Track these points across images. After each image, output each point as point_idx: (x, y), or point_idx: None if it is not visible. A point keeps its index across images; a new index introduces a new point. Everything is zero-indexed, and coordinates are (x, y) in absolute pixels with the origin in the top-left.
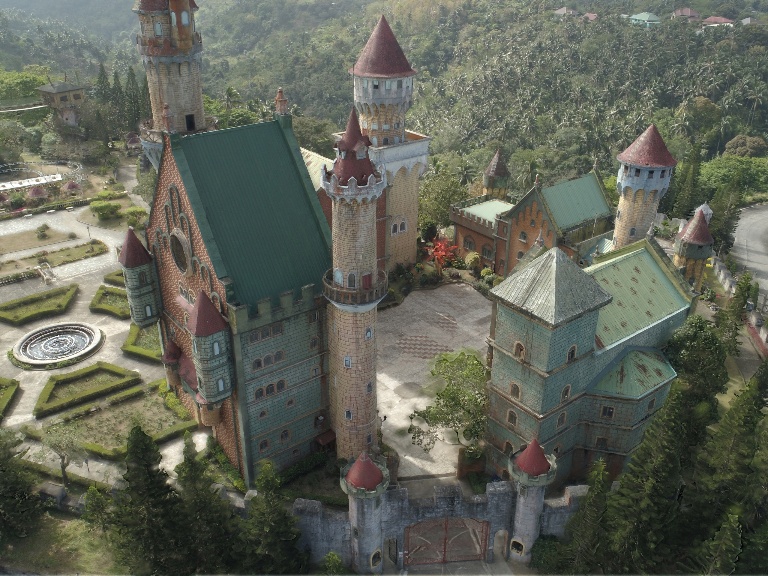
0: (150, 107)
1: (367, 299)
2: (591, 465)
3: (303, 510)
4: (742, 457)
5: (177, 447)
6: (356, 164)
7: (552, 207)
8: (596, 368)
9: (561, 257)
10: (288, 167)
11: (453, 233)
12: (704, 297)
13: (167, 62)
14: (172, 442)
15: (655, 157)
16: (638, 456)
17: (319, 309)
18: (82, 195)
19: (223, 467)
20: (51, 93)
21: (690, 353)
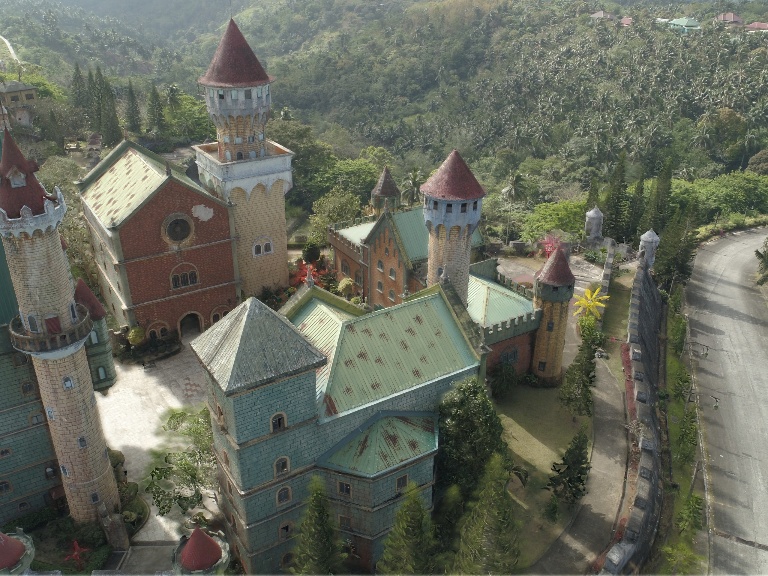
0: (111, 108)
1: (48, 346)
2: (339, 546)
3: None
4: (410, 574)
5: None
6: (12, 193)
7: (405, 235)
8: (330, 437)
9: (257, 309)
10: None
11: (333, 256)
12: None
13: None
14: None
15: (453, 188)
16: (300, 559)
17: None
18: None
19: None
20: (2, 93)
21: (458, 423)
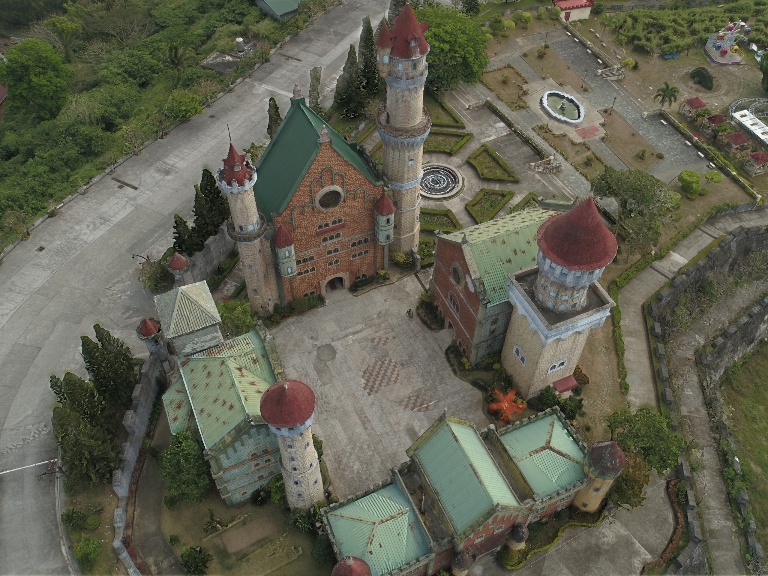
0: None
1: None
2: None
3: None
4: None
5: None
6: None
7: (435, 442)
8: None
9: None
10: None
11: None
12: None
13: None
14: None
15: None
16: None
17: None
18: (755, 169)
19: None
20: None
21: None
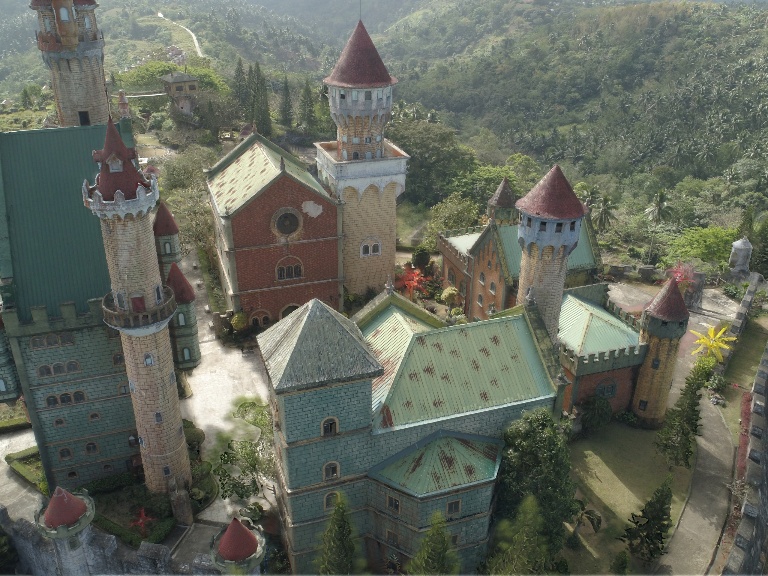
0: (264, 102)
1: (132, 323)
2: (386, 560)
3: (17, 531)
4: None
5: (31, 436)
6: (110, 177)
7: (509, 249)
8: (384, 449)
9: (319, 311)
10: None
11: (442, 263)
12: (708, 385)
13: (55, 57)
14: (31, 430)
15: (549, 206)
16: None
17: None
18: None
19: None
20: (169, 82)
21: (521, 455)
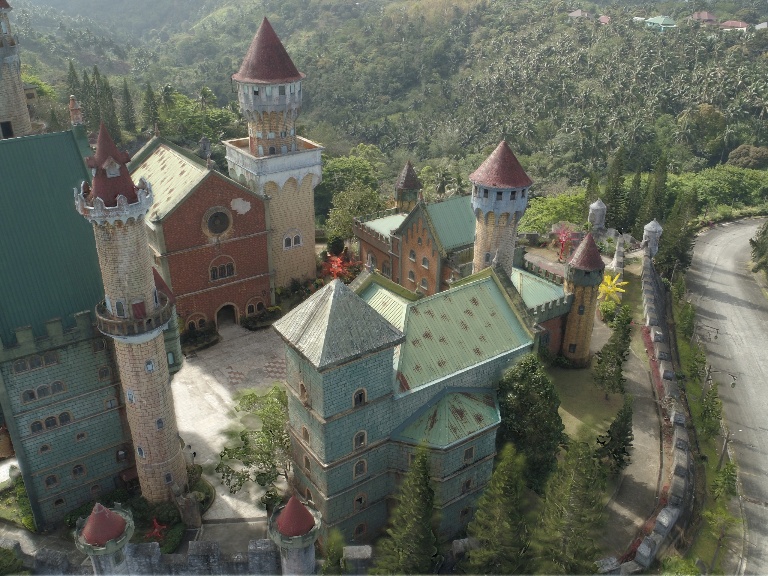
0: (110, 107)
1: (136, 330)
2: None
3: (43, 562)
4: (506, 530)
5: None
6: (107, 183)
7: (438, 225)
8: (402, 412)
9: (342, 290)
10: (80, 181)
11: (358, 248)
12: (613, 324)
13: None
14: None
15: (503, 177)
16: (397, 521)
17: (105, 337)
18: None
19: (18, 501)
20: None
21: (519, 397)
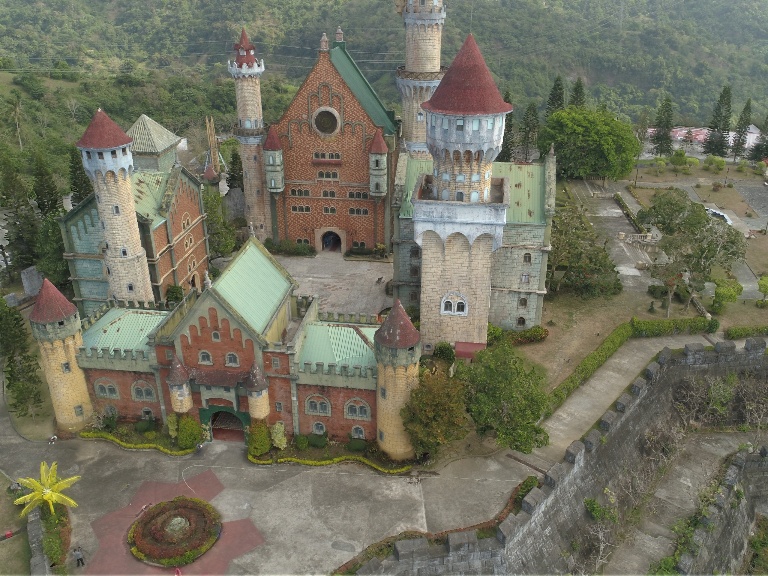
0: None
1: None
2: None
3: None
4: None
5: None
6: None
7: None
8: None
9: None
10: None
11: None
12: None
13: None
14: None
15: None
16: None
17: None
18: None
19: None
20: None
21: None
